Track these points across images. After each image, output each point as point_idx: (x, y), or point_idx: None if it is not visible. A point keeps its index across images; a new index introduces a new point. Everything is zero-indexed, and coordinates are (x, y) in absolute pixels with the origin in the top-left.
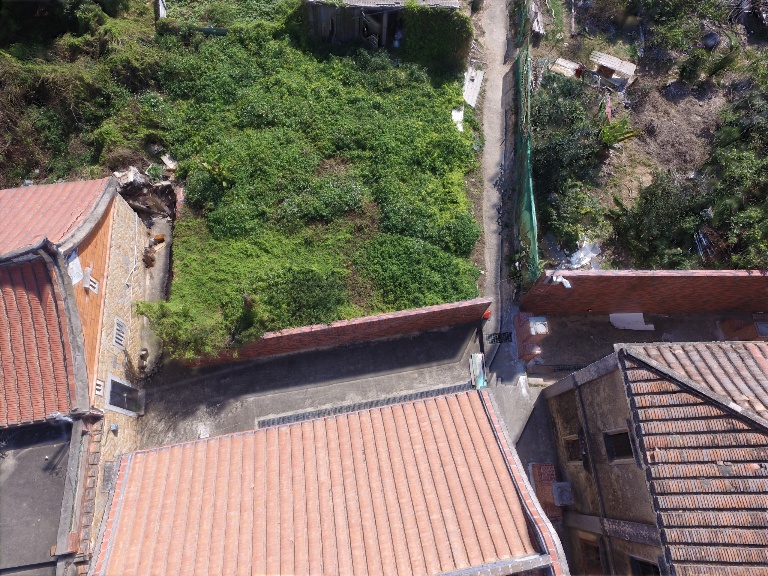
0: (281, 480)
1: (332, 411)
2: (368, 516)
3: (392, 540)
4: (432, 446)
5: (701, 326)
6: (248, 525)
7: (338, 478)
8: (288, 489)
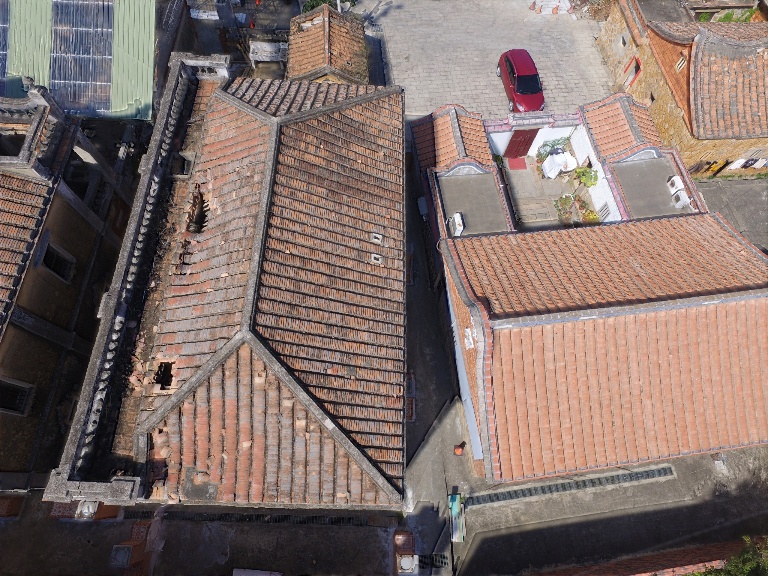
0: (683, 403)
1: (604, 482)
2: (613, 368)
3: (596, 349)
4: (555, 425)
5: (173, 573)
6: (705, 368)
7: (636, 402)
8: (677, 395)
